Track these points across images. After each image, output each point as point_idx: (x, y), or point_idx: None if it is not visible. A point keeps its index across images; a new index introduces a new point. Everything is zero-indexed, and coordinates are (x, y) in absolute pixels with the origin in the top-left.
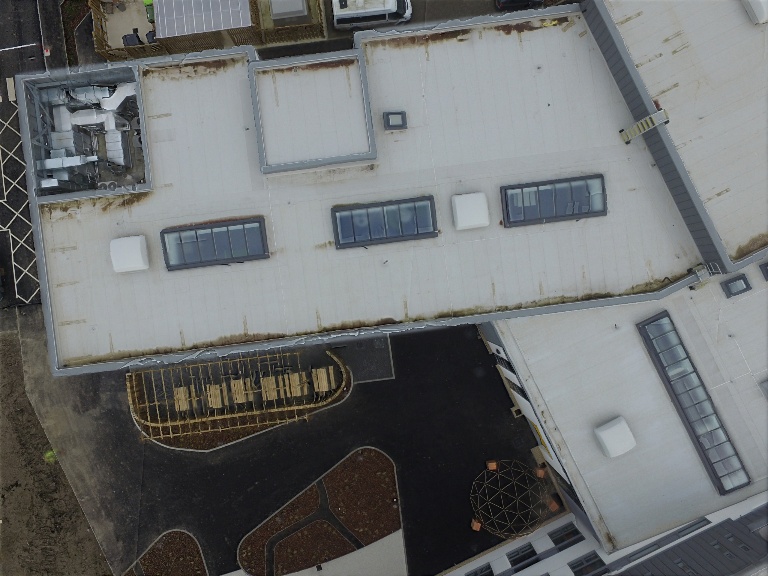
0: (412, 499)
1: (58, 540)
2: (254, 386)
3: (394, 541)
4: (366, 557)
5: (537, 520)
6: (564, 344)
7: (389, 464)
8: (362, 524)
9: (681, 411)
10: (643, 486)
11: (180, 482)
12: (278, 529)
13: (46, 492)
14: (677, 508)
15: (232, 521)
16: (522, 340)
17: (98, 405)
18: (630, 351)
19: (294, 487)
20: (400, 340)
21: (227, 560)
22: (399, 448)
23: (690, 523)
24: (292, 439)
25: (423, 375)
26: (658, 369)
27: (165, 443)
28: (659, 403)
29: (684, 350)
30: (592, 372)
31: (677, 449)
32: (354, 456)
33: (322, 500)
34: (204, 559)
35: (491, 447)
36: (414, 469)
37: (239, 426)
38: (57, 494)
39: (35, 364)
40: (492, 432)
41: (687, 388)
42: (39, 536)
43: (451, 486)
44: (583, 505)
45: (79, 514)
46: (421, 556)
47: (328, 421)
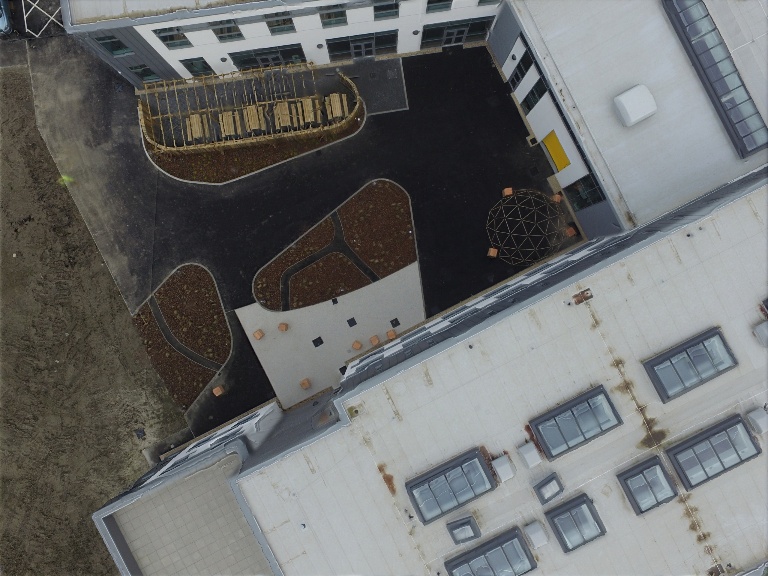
0: (428, 231)
1: (72, 274)
2: (267, 116)
3: (410, 273)
4: (382, 290)
5: (555, 234)
6: (582, 17)
7: (404, 196)
8: (377, 256)
9: (702, 73)
10: (664, 159)
11: (194, 215)
12: (293, 261)
13: (59, 226)
14: (699, 179)
15: (247, 254)
16: (539, 16)
17: (110, 139)
18: (650, 18)
19: (308, 220)
20: (413, 70)
21: (242, 293)
22: (414, 180)
23: (712, 190)
24: (306, 172)
25: (437, 105)
26: (678, 31)
27: (178, 176)
28: (680, 70)
29: (705, 6)
30: (611, 44)
31: (698, 117)
32: (369, 188)
33: (337, 232)
34: (219, 293)
35: (507, 177)
36: (429, 201)
37: (253, 137)
38: (70, 228)
39: (46, 98)
40: (508, 162)
41: (708, 46)
42: (53, 270)
43: (467, 217)
44: (603, 184)
45: (93, 248)
46: (437, 287)
47: (342, 154)
